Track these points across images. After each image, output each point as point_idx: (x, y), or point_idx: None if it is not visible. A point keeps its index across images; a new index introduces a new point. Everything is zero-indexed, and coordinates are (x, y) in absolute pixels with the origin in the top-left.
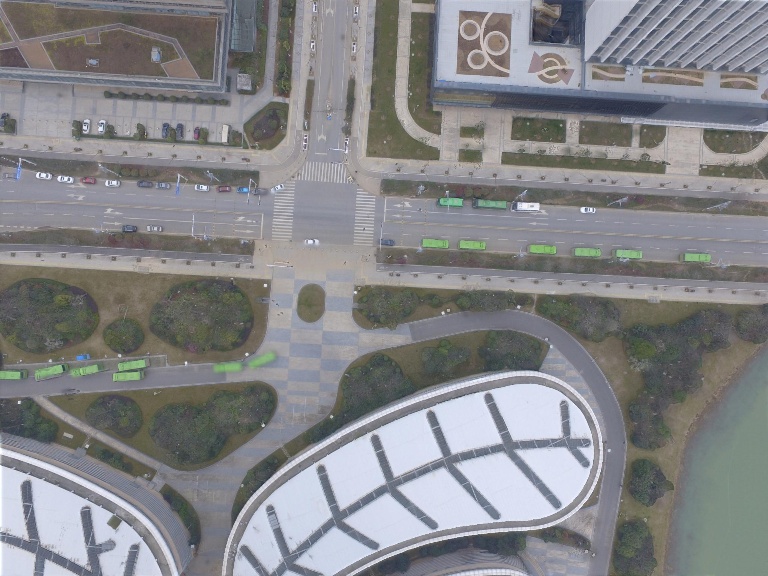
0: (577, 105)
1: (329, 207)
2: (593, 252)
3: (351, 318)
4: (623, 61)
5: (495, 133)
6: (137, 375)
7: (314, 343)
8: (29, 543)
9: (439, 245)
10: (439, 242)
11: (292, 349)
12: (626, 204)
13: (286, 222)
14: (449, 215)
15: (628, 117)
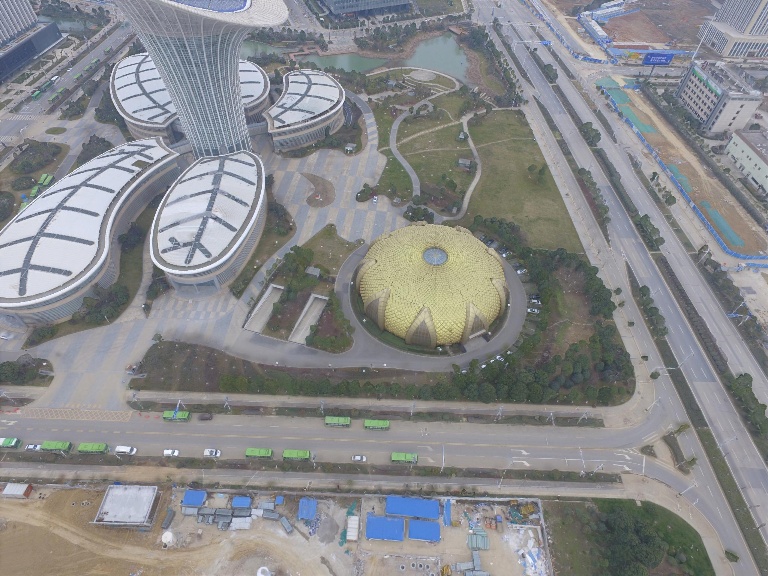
0: (15, 59)
1: (9, 126)
2: (87, 66)
3: (73, 121)
4: (4, 45)
5: (14, 87)
6: (50, 176)
7: (78, 130)
8: (101, 169)
9: (54, 96)
10: (52, 96)
11: (76, 136)
12: (74, 62)
13: (6, 138)
14: (43, 98)
15: (34, 57)
